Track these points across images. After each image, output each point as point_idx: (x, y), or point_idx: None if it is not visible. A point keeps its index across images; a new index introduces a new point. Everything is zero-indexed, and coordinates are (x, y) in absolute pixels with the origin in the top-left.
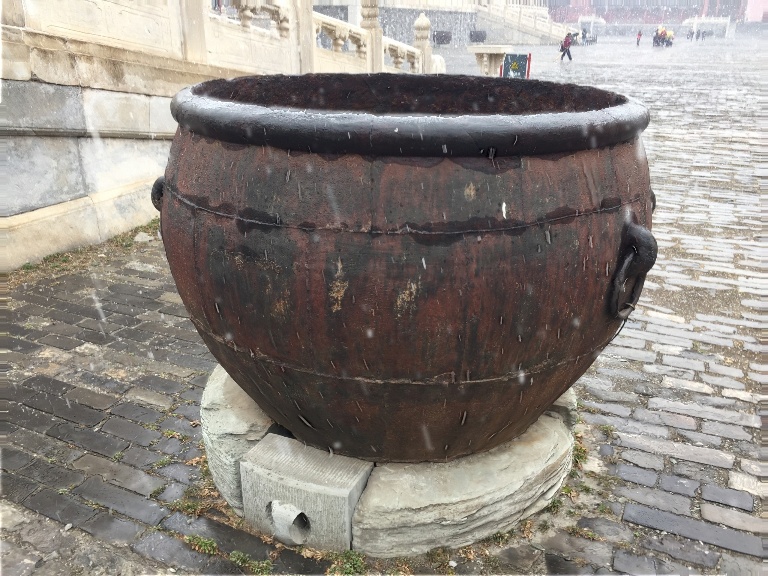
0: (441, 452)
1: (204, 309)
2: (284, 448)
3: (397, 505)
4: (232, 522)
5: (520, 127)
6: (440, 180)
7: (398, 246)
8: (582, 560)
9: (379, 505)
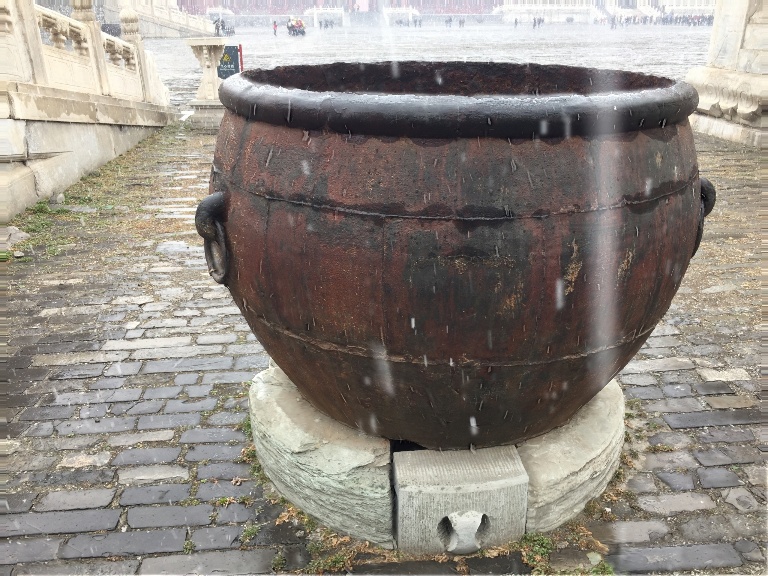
0: (571, 414)
1: (385, 329)
2: (426, 461)
3: (563, 473)
4: (389, 558)
5: (680, 98)
6: (640, 152)
7: (619, 219)
8: (681, 468)
9: (549, 479)
